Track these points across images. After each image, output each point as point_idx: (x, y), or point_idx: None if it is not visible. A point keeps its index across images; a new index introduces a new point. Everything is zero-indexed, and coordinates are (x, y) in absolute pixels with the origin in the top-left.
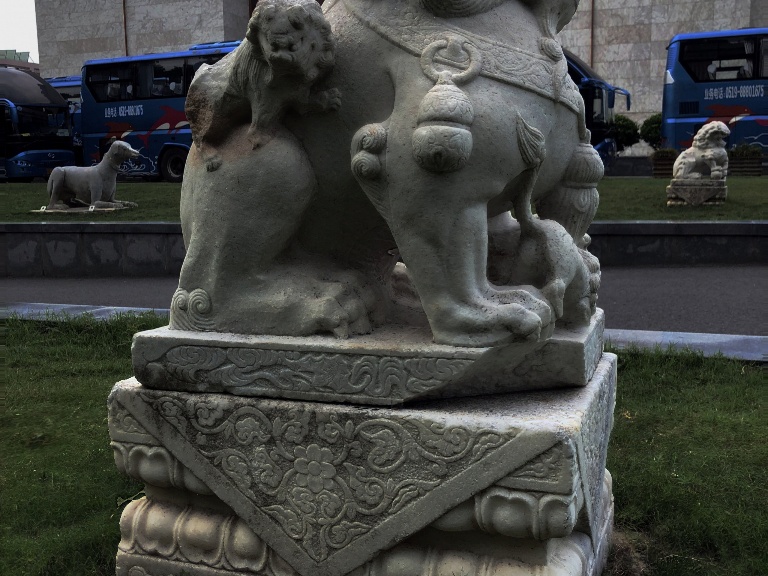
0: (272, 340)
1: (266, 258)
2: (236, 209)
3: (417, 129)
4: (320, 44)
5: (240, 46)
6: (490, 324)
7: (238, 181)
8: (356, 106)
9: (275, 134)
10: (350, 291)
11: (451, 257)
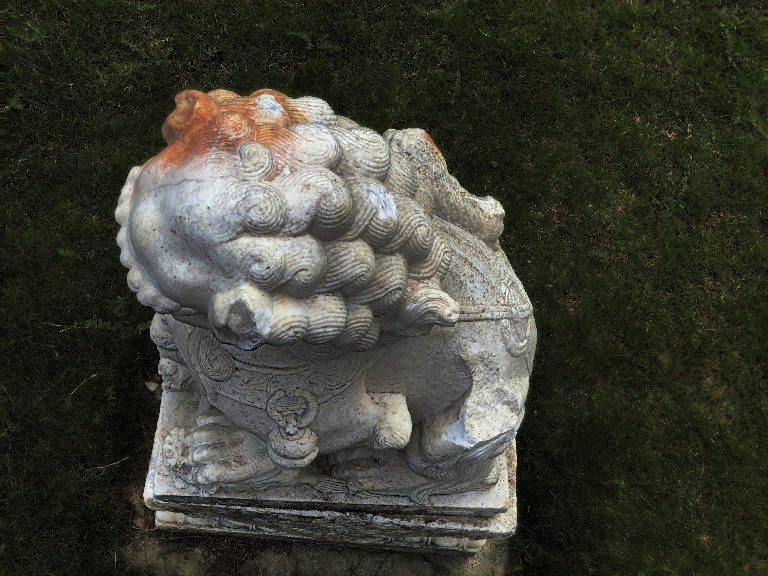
0: None
1: None
2: None
3: None
4: None
5: None
6: None
7: None
8: None
9: None
10: None
11: None
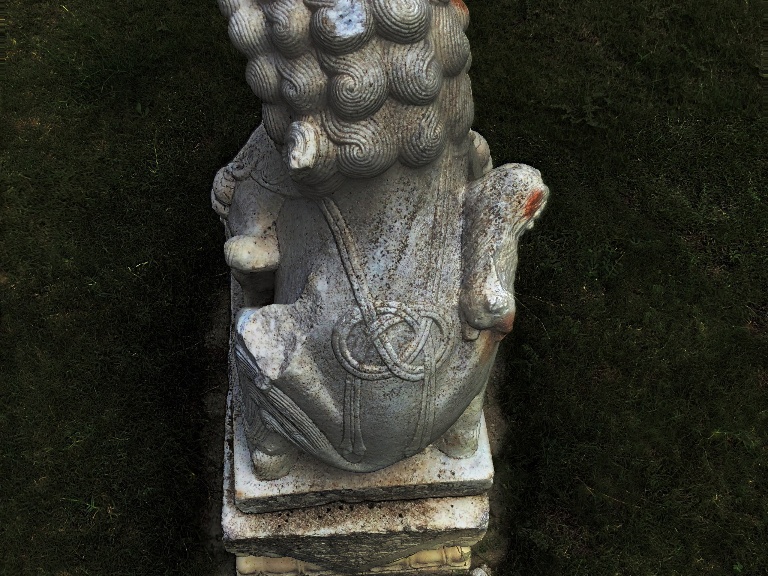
0: None
1: None
2: None
3: None
4: None
5: (513, 246)
6: None
7: None
8: None
9: None
10: None
11: None
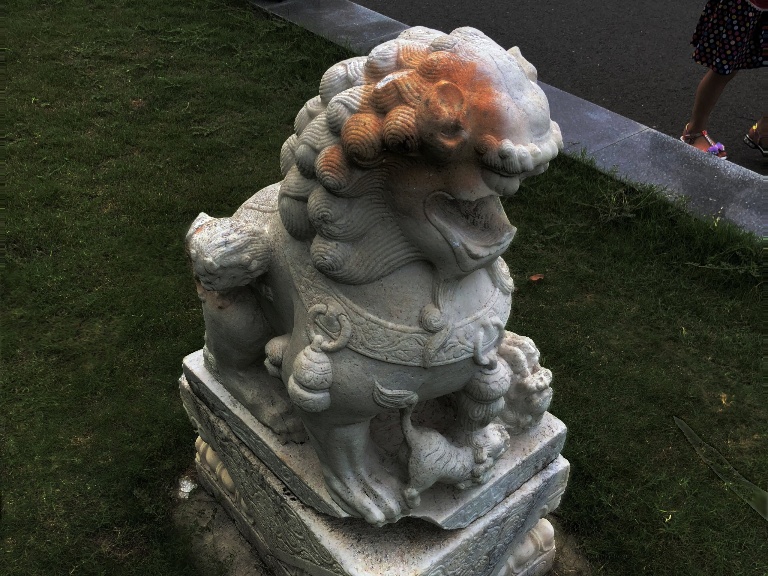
0: (245, 418)
1: (241, 366)
2: (216, 335)
3: (290, 378)
4: (241, 273)
5: None
6: (349, 504)
7: (213, 320)
8: (281, 310)
9: (235, 298)
10: (292, 412)
11: (327, 451)
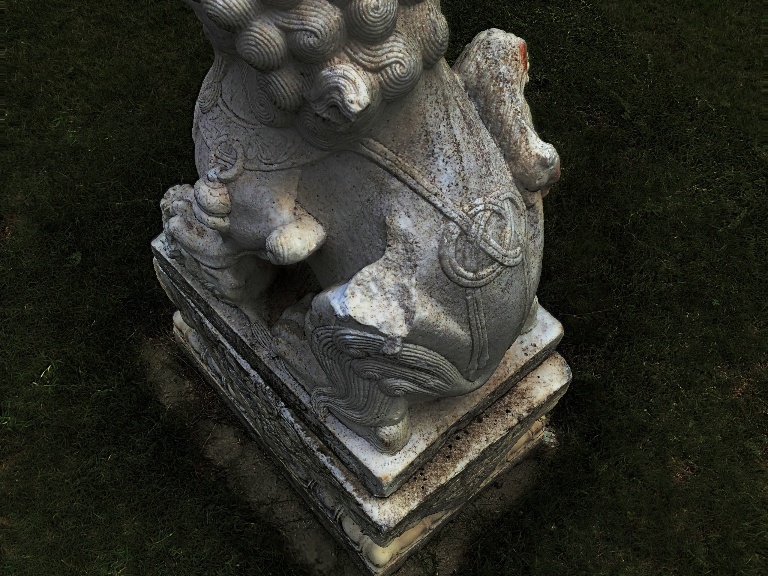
0: None
1: None
2: None
3: None
4: None
5: None
6: None
7: None
8: None
9: None
10: None
11: None
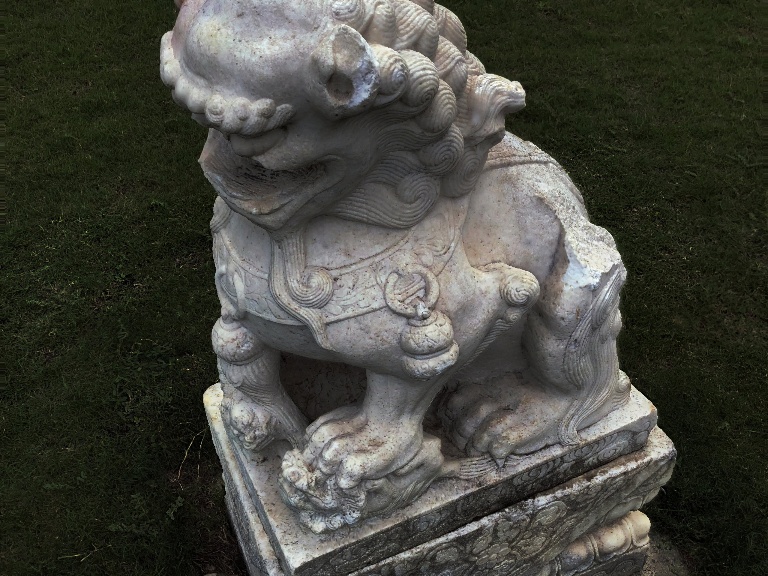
0: None
1: None
2: None
3: None
4: None
5: None
6: None
7: None
8: None
9: None
10: None
11: None
